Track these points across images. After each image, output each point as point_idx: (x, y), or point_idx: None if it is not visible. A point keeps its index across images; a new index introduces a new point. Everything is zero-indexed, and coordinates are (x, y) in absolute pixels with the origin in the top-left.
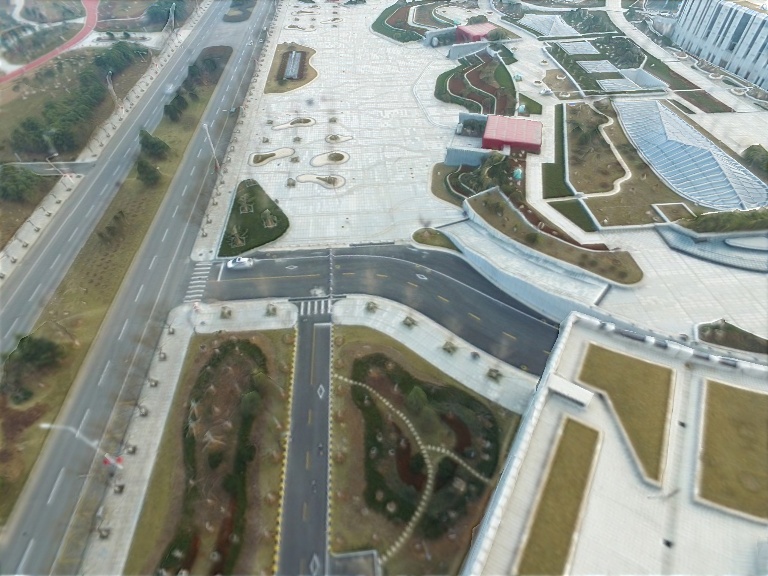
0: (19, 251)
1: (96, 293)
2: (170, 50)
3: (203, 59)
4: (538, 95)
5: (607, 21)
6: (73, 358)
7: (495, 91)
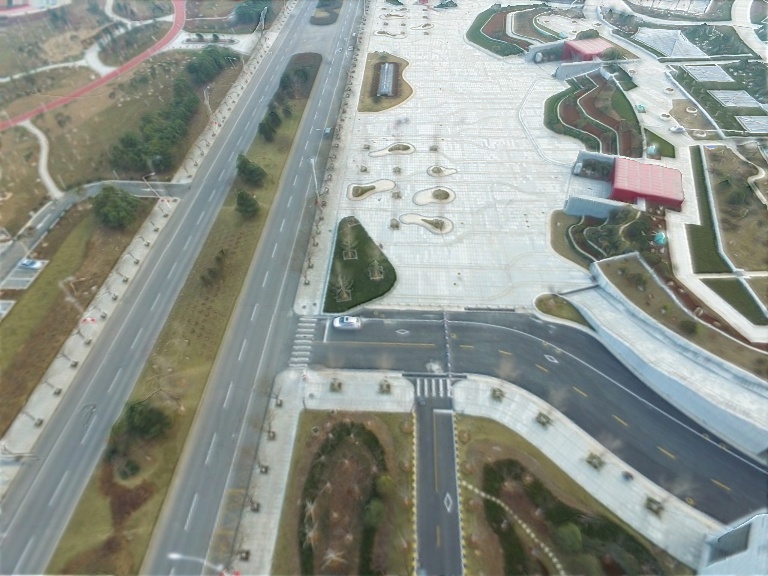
0: (120, 286)
1: (199, 346)
2: (259, 56)
3: (295, 70)
4: (667, 132)
5: (737, 40)
6: (179, 427)
7: (616, 124)
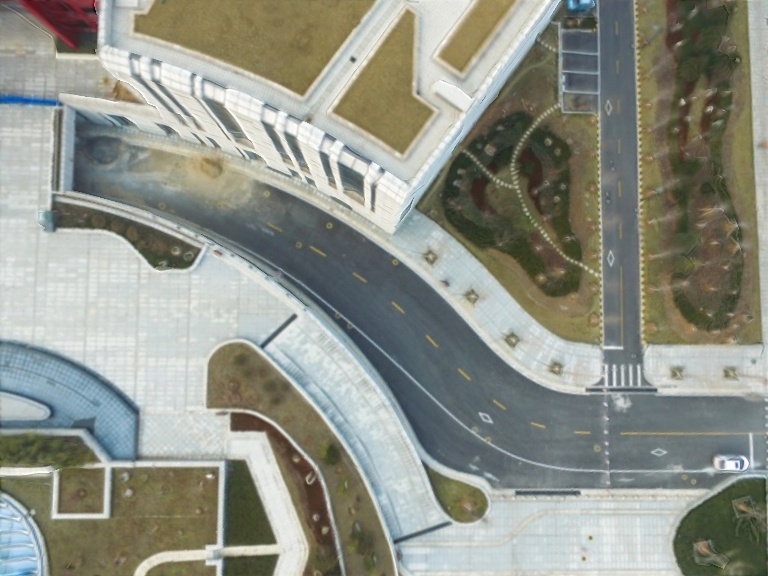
0: None
1: None
2: None
3: None
4: None
5: None
6: None
7: None
